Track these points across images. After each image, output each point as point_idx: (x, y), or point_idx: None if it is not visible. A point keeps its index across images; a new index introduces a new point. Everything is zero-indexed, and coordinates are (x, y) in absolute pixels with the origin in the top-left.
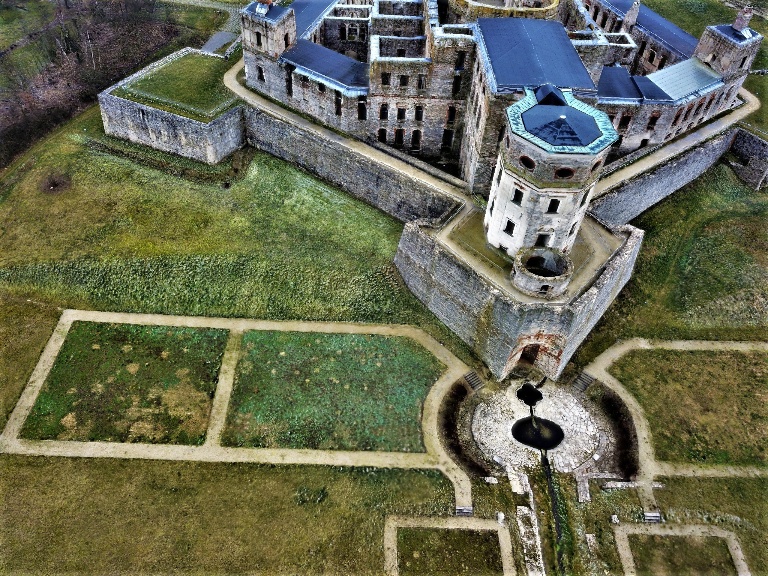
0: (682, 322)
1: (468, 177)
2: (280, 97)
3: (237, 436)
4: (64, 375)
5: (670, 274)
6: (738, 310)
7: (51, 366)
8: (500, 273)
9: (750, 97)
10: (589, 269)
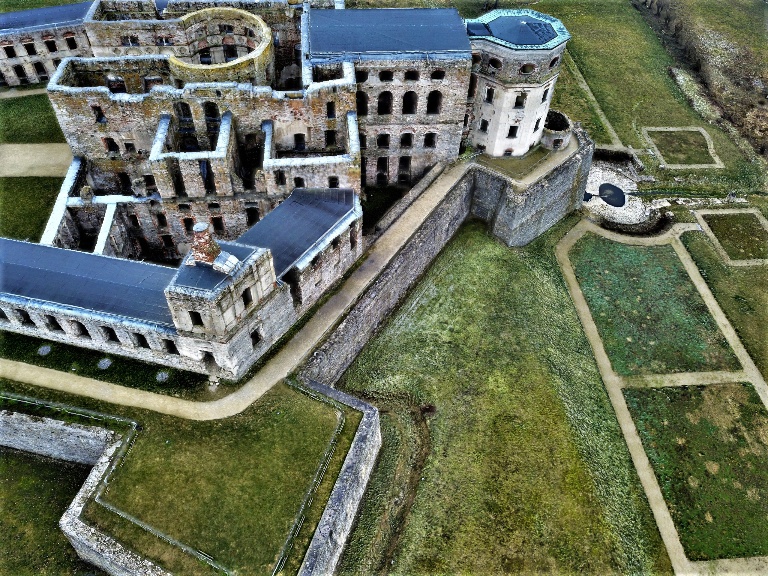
0: None
1: (434, 160)
2: (286, 326)
3: (728, 359)
4: (760, 537)
5: None
6: None
7: (759, 557)
8: (551, 155)
9: None
10: None
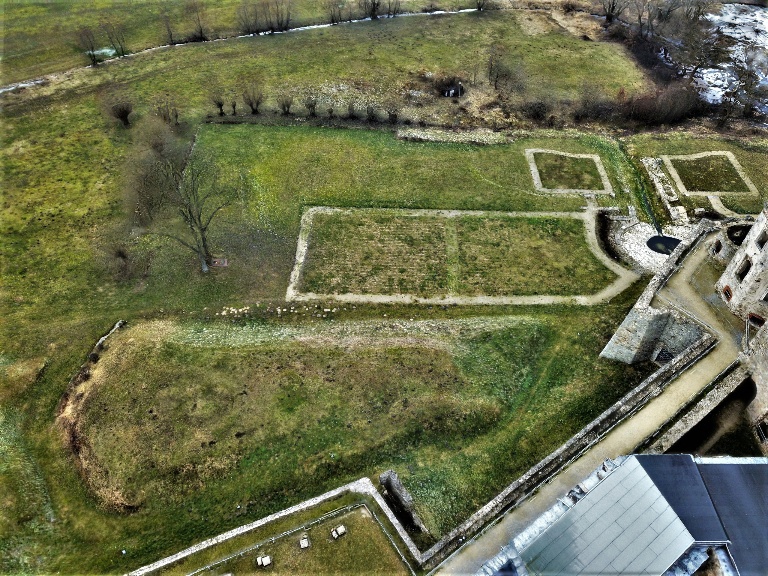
0: (540, 318)
1: None
2: None
3: None
4: None
5: (546, 368)
6: (480, 324)
7: None
8: None
9: None
10: (690, 269)
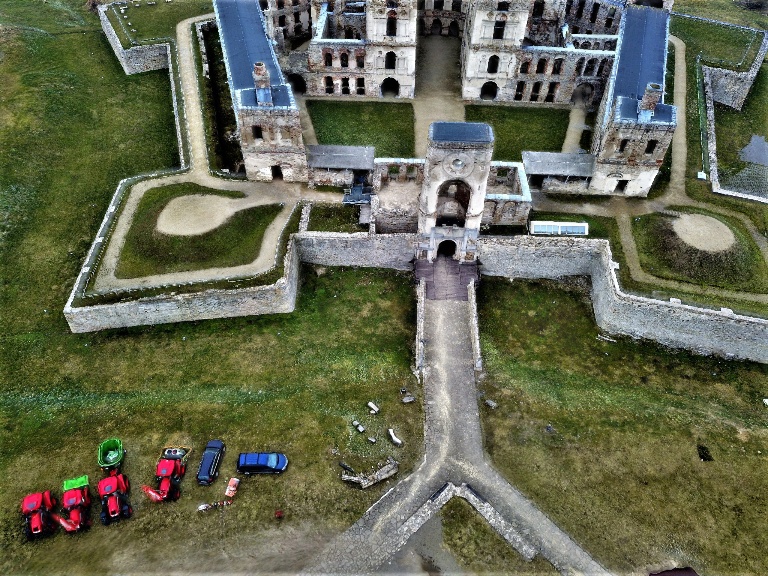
0: None
1: None
2: None
3: None
4: None
5: None
6: None
7: None
8: None
9: (183, 26)
10: None
